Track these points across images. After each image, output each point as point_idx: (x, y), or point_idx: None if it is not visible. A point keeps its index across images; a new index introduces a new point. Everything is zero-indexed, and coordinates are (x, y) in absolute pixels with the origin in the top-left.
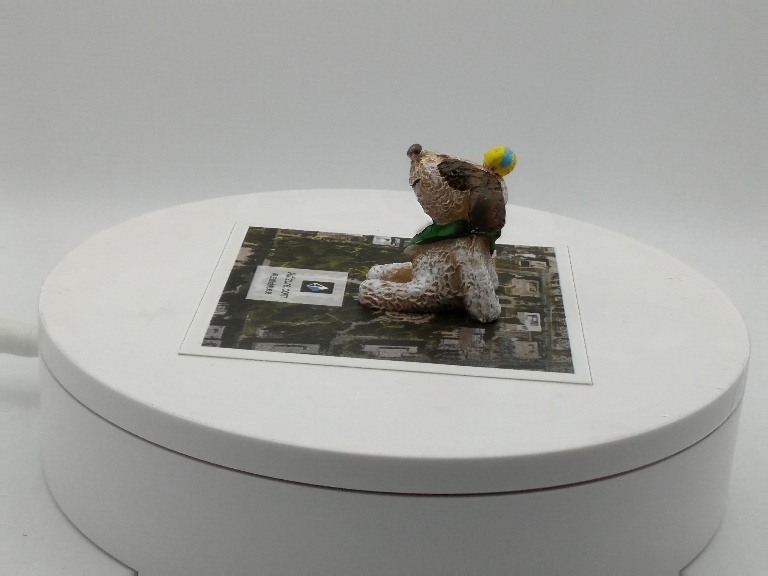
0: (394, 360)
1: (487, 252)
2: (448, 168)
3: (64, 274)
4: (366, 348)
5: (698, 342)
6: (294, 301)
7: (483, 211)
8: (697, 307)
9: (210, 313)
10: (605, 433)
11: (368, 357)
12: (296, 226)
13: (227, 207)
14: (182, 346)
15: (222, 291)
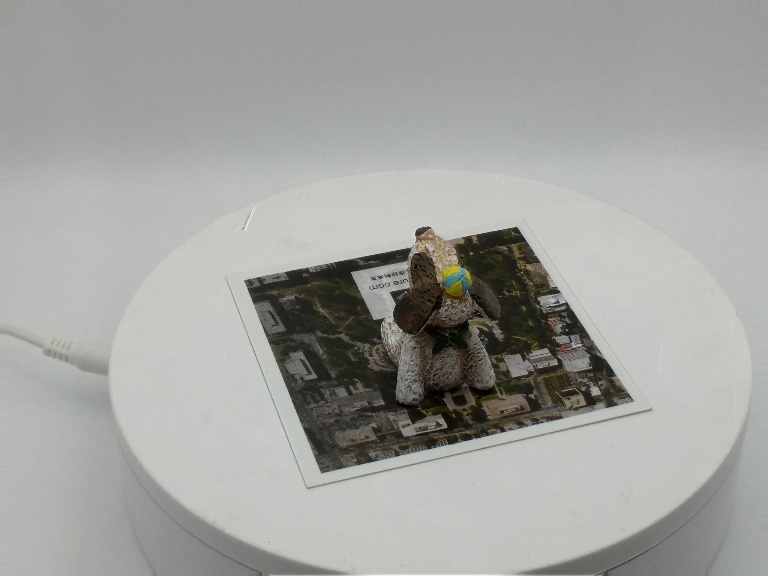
0: (281, 373)
1: (431, 349)
2: (416, 261)
3: (336, 184)
4: (295, 353)
5: (460, 539)
6: (365, 295)
7: (404, 311)
8: (556, 526)
9: (309, 265)
10: (215, 513)
11: (278, 359)
12: (541, 248)
13: (556, 203)
14: (237, 273)
15: (357, 257)
